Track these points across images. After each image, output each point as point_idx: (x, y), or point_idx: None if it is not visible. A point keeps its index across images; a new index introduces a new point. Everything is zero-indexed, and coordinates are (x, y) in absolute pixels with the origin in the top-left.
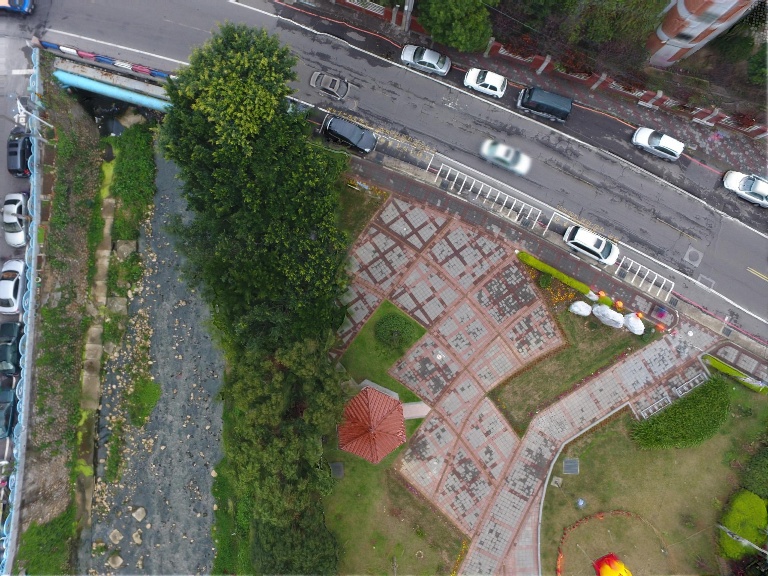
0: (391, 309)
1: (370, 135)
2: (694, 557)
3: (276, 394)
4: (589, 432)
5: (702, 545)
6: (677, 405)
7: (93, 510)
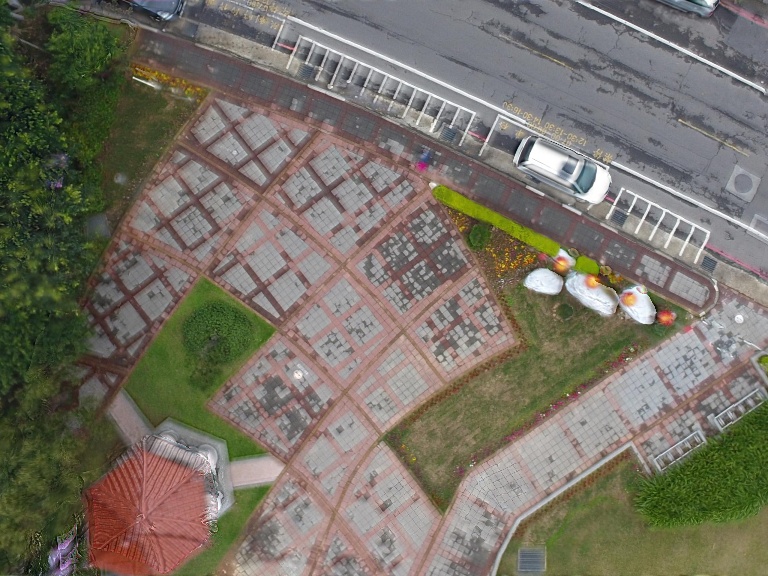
0: (212, 293)
1: None
2: None
3: None
4: (563, 497)
5: None
6: (716, 445)
7: None
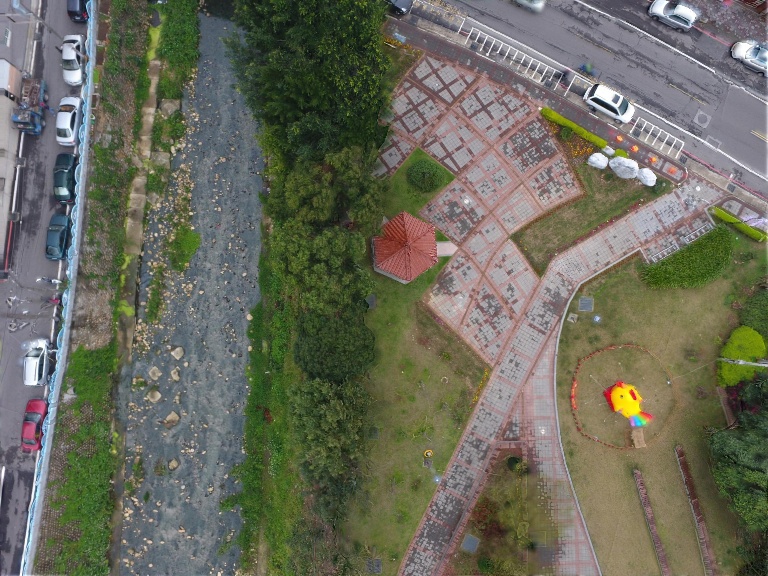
0: (423, 156)
1: None
2: (697, 388)
3: (326, 189)
4: (603, 274)
5: (705, 378)
6: (685, 250)
7: (134, 348)
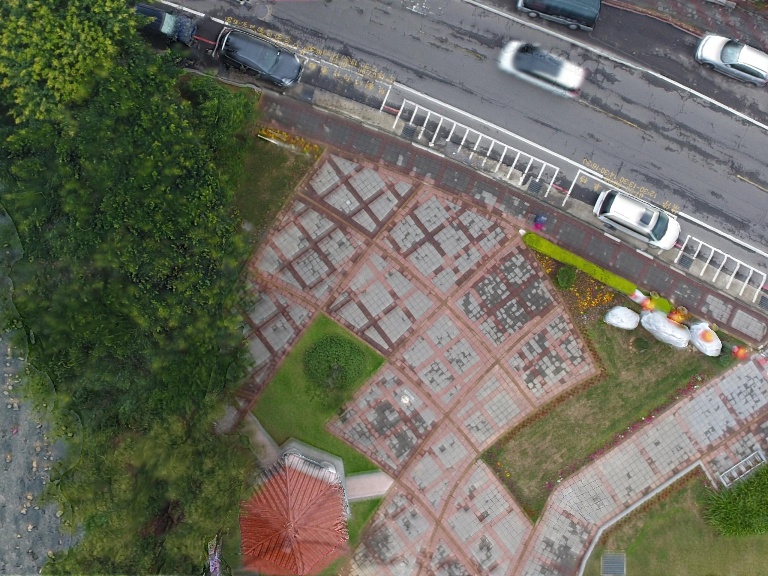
0: (329, 327)
1: (290, 57)
2: None
3: (120, 477)
4: (640, 509)
5: None
6: None
7: None
